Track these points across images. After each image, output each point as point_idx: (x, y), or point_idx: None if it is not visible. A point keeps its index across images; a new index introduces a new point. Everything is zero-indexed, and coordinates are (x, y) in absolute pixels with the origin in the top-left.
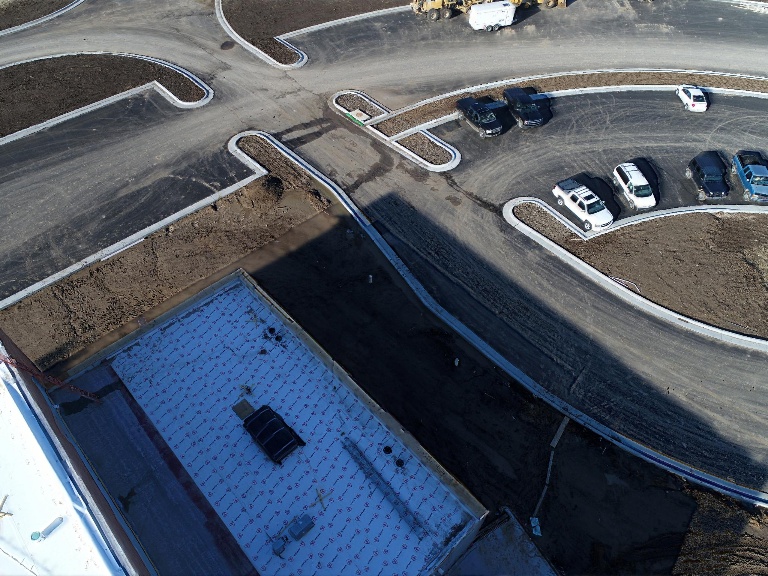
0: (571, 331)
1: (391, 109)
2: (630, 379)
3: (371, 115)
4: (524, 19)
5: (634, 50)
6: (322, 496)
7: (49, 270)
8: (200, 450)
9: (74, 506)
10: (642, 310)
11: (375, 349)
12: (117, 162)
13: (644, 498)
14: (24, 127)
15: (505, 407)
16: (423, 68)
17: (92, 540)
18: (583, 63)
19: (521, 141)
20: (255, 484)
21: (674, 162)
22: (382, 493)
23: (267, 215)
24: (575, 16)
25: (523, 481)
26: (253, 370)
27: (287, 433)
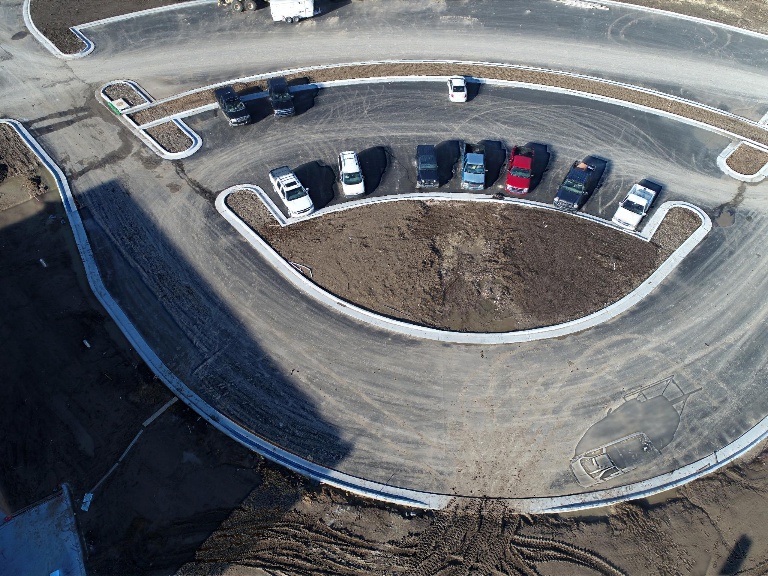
0: (225, 314)
1: (155, 98)
2: (260, 361)
3: (133, 104)
4: (330, 11)
5: (427, 42)
6: None
7: None
8: None
9: None
10: (306, 294)
11: (16, 331)
12: None
13: (210, 475)
14: None
15: (117, 387)
16: (206, 58)
17: None
18: (369, 54)
19: (269, 130)
20: None
21: (410, 151)
22: None
23: None
24: (383, 8)
25: (98, 458)
26: None
27: None
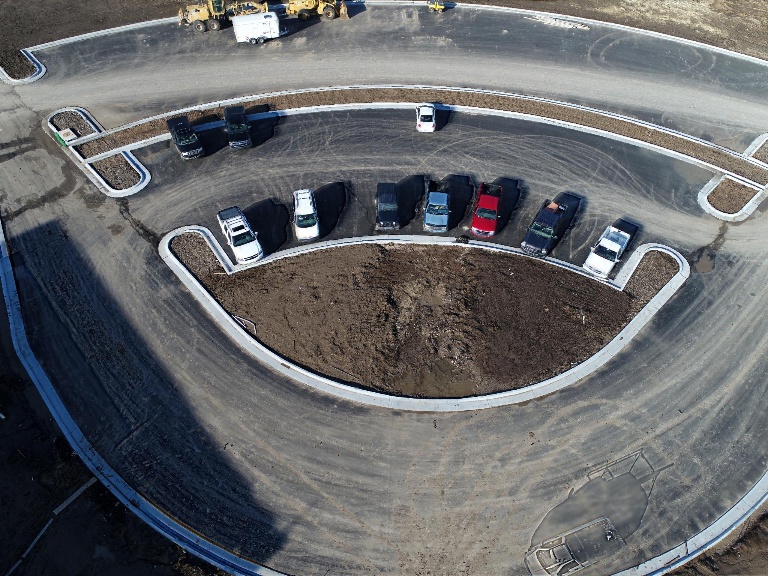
0: (157, 378)
1: (105, 128)
2: (191, 433)
3: (80, 134)
4: (298, 31)
5: (397, 65)
6: None
7: None
8: None
9: None
10: (248, 354)
11: None
12: None
13: (123, 574)
14: None
15: (30, 466)
16: (163, 83)
17: None
18: (336, 78)
19: (223, 164)
20: None
21: (372, 187)
22: None
23: None
24: (354, 28)
25: None
26: None
27: None
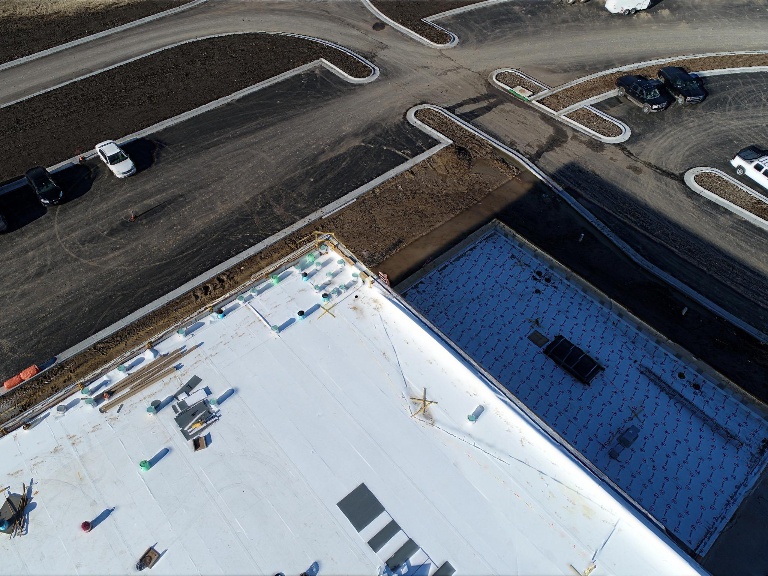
0: None
1: (550, 86)
2: None
3: (533, 91)
4: (656, 4)
5: None
6: (636, 412)
7: (278, 226)
8: (512, 372)
9: (496, 395)
10: None
11: None
12: (308, 131)
13: None
14: (214, 99)
15: (739, 352)
16: (571, 49)
17: (525, 422)
18: (725, 45)
19: (684, 116)
20: (572, 401)
21: None
22: (690, 411)
23: (463, 180)
24: (706, 1)
25: None
26: (534, 306)
27: (591, 358)
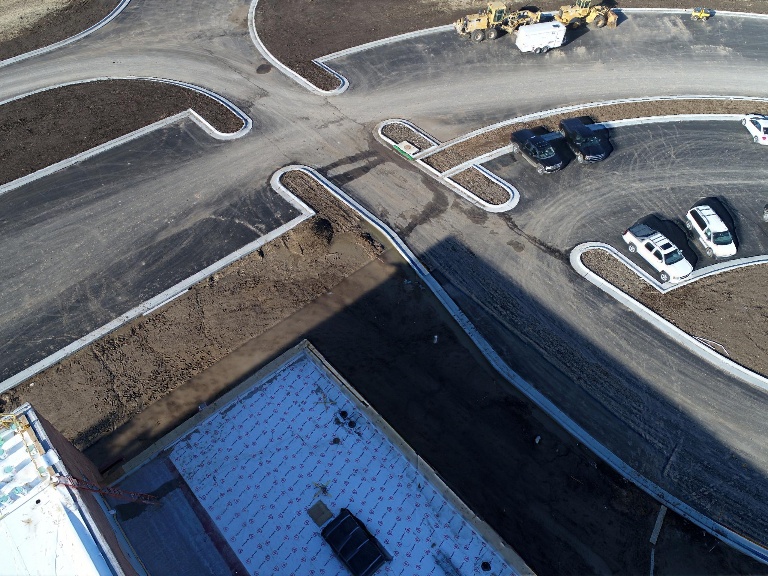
0: (658, 401)
1: (440, 141)
2: (728, 459)
3: (420, 147)
4: (573, 40)
5: (692, 75)
6: None
7: (88, 326)
8: (275, 566)
9: None
10: (733, 376)
11: (446, 422)
12: (154, 201)
13: None
14: (55, 161)
15: (595, 494)
16: (471, 94)
17: None
18: (640, 89)
19: (582, 178)
20: None
21: (749, 202)
22: None
23: (317, 262)
24: (626, 37)
25: None
26: (327, 464)
27: (373, 547)
